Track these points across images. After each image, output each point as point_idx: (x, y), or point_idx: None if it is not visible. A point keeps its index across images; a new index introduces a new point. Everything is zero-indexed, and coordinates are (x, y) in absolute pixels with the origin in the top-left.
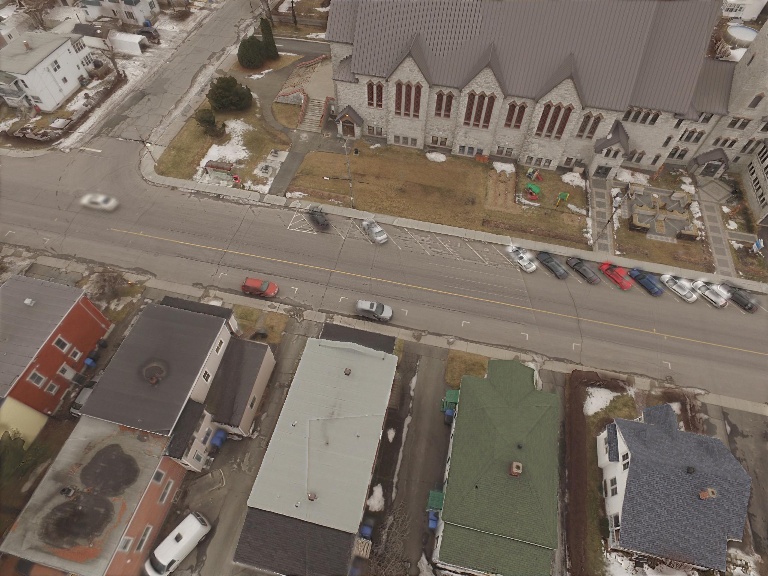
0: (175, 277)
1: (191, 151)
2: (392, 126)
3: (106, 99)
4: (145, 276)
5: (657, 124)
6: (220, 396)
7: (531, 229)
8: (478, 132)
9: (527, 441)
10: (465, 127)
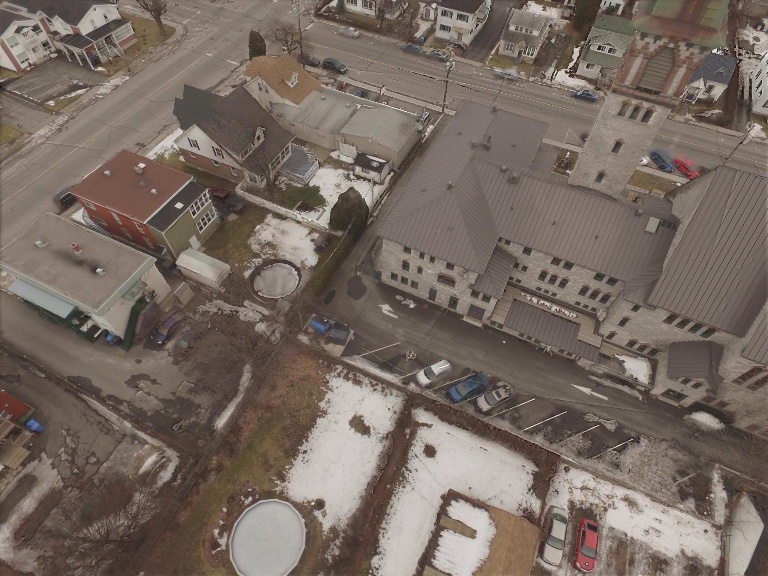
0: None
1: None
2: None
3: None
4: None
5: None
6: None
7: None
8: None
9: None
10: None
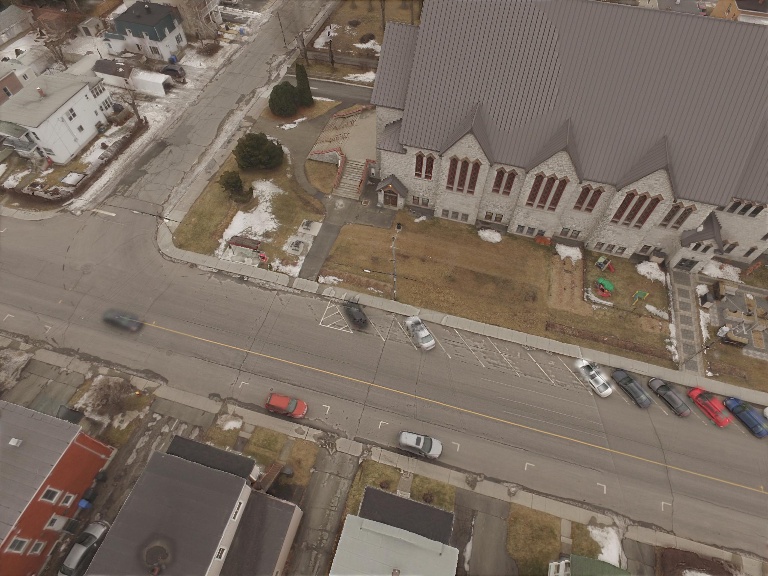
0: (189, 384)
1: (214, 219)
2: (441, 200)
3: (124, 150)
4: (155, 382)
5: (759, 217)
6: (236, 575)
7: (604, 337)
8: (542, 214)
9: None
10: (527, 208)
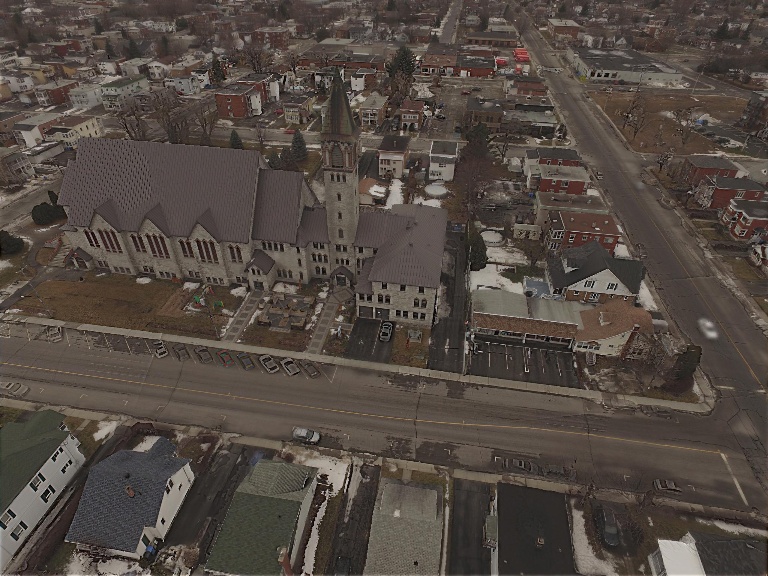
0: None
1: None
2: (109, 260)
3: None
4: None
5: (286, 251)
6: None
7: (181, 327)
8: (165, 261)
9: (6, 459)
10: (155, 258)
